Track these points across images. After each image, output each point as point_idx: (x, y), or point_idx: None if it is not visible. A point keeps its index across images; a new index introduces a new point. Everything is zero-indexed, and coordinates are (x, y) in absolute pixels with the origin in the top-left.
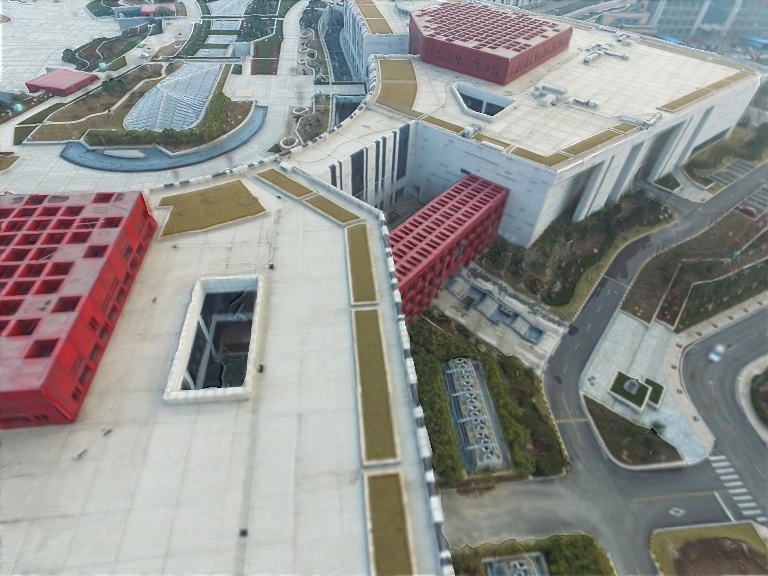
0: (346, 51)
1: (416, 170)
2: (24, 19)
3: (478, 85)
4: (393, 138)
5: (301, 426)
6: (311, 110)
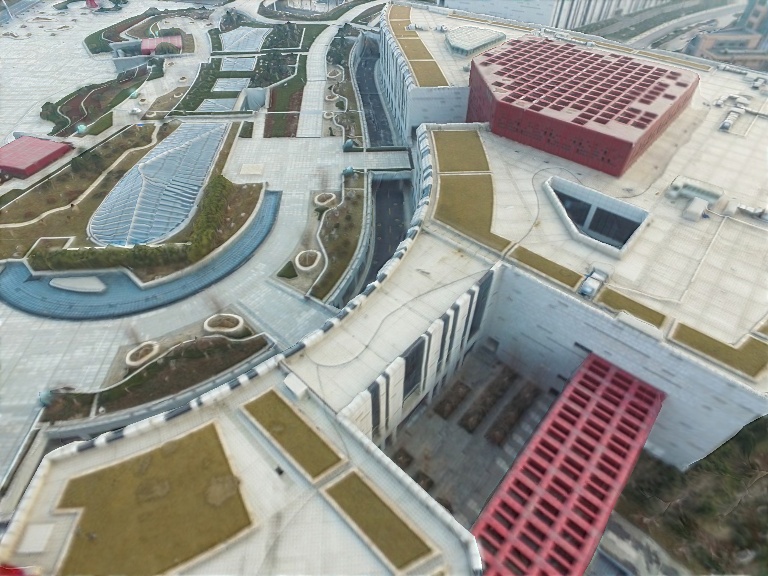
0: (383, 93)
1: (496, 322)
2: (12, 59)
3: (581, 177)
4: (469, 300)
5: None
6: (339, 196)
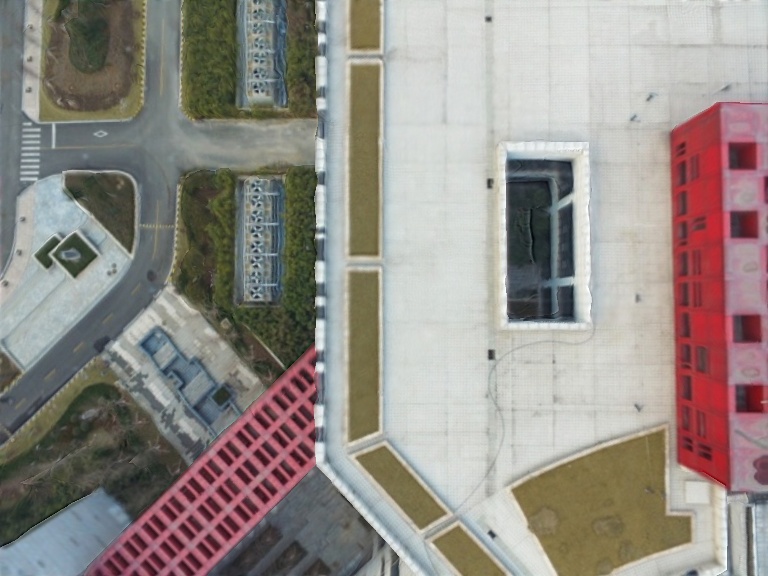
0: None
1: None
2: None
3: None
4: None
5: (442, 109)
6: None
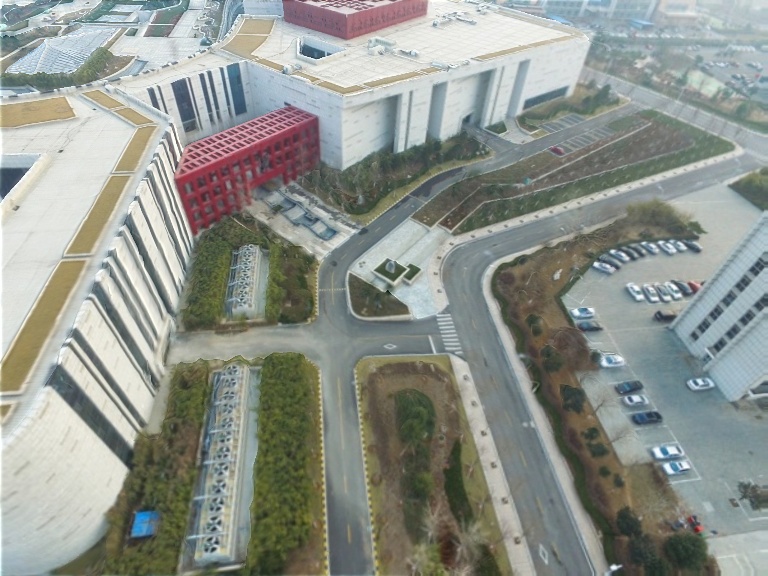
0: None
1: (256, 107)
2: None
3: (324, 39)
4: (220, 73)
5: (29, 238)
6: None
